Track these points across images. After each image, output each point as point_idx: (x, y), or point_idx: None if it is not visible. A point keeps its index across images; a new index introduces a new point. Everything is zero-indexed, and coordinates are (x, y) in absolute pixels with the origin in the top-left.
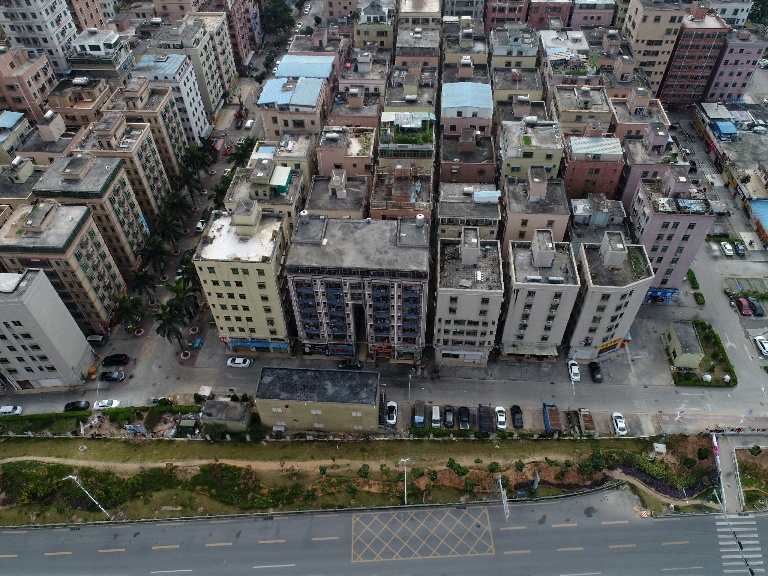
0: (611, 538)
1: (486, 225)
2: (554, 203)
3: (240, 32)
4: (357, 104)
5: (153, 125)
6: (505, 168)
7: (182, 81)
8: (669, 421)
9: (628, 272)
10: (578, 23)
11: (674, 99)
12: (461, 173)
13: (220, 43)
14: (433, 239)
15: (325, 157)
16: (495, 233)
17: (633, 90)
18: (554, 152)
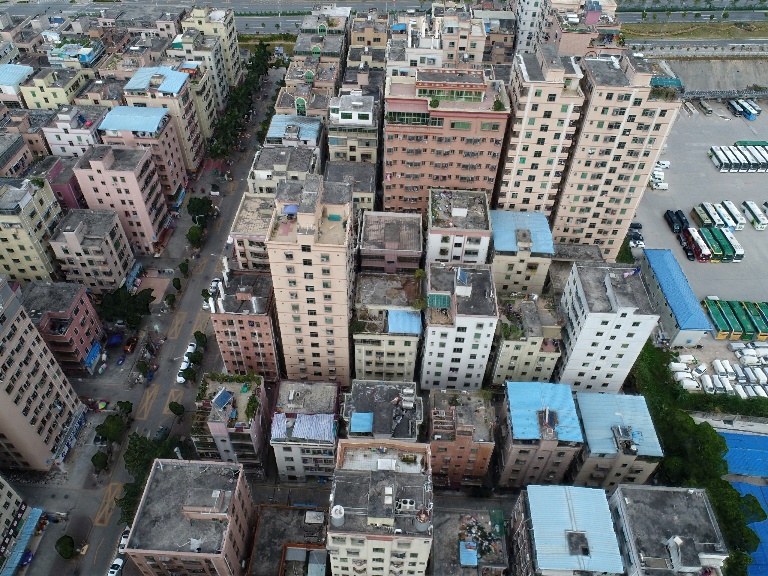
0: None
1: None
2: None
3: None
4: None
5: None
6: None
7: None
8: None
9: None
10: None
11: None
12: None
13: None
14: None
15: None
16: None
17: None
18: None
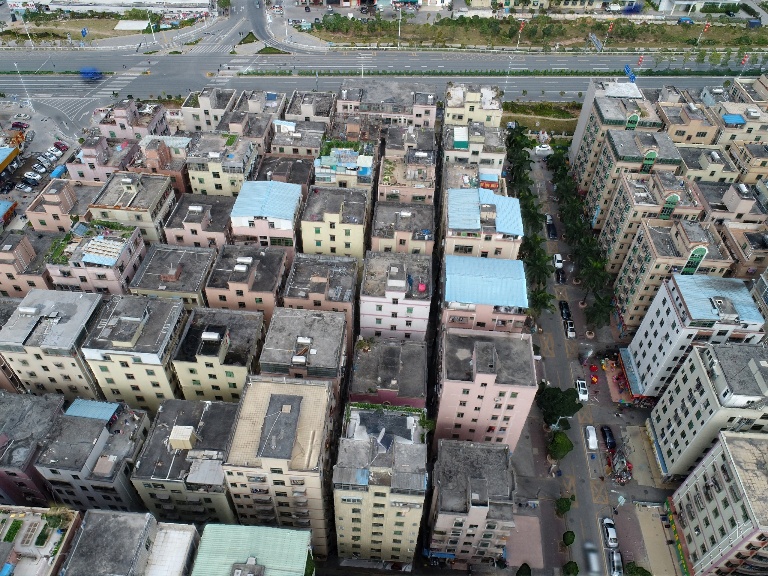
0: None
1: None
2: None
3: None
4: None
5: None
6: None
7: None
8: None
9: None
10: None
11: None
12: None
13: None
14: None
15: None
16: None
17: (62, 193)
18: None
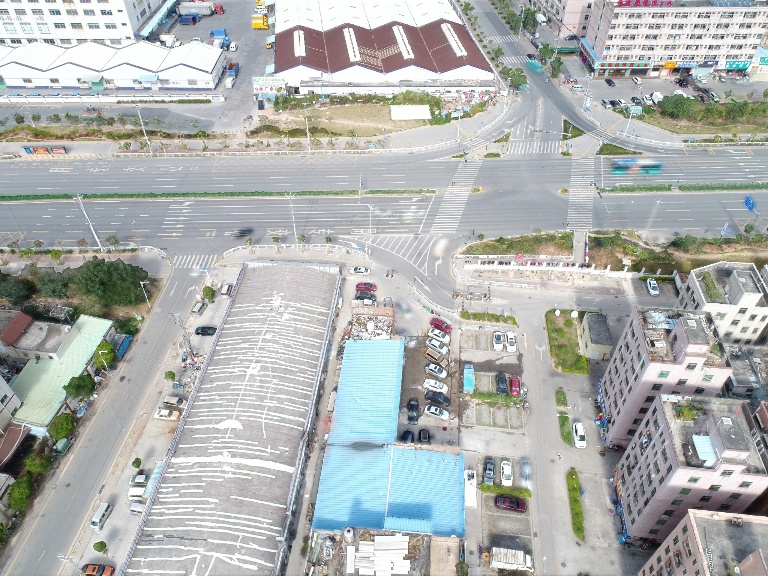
0: (661, 223)
1: None
2: None
3: None
4: None
5: None
6: None
7: None
8: (611, 289)
9: (716, 284)
10: None
11: None
12: None
13: None
14: None
15: None
16: None
17: None
18: None
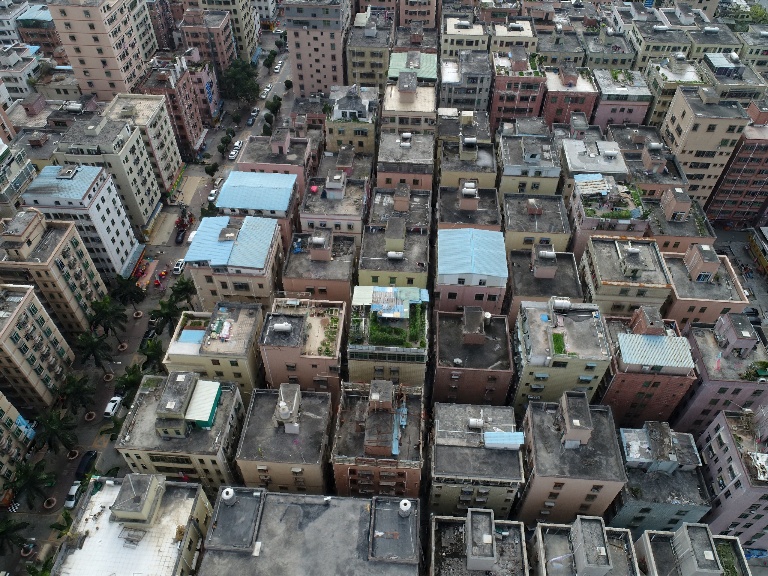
0: None
1: (502, 485)
2: (601, 452)
3: (188, 111)
4: (323, 256)
5: (44, 278)
6: (526, 376)
7: (93, 205)
8: None
9: None
10: (604, 116)
11: (723, 216)
12: (464, 378)
13: (157, 136)
14: (424, 492)
15: (272, 356)
16: (514, 492)
17: (695, 248)
18: (597, 363)
